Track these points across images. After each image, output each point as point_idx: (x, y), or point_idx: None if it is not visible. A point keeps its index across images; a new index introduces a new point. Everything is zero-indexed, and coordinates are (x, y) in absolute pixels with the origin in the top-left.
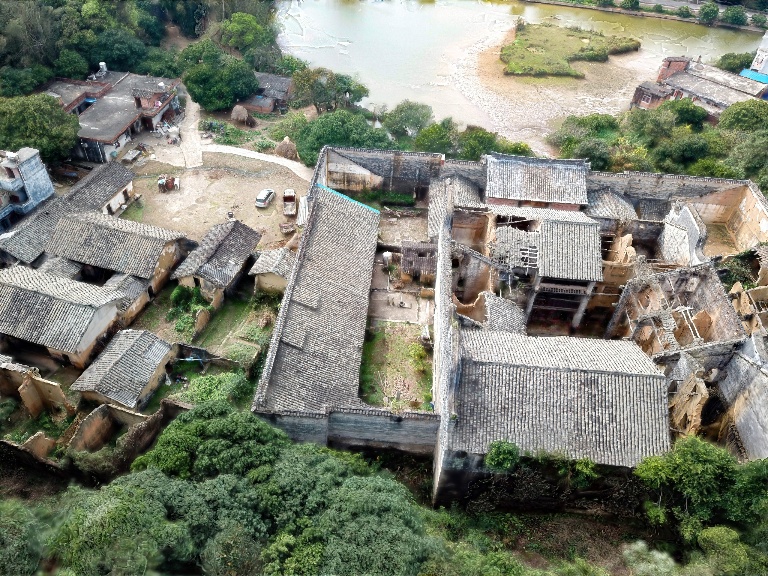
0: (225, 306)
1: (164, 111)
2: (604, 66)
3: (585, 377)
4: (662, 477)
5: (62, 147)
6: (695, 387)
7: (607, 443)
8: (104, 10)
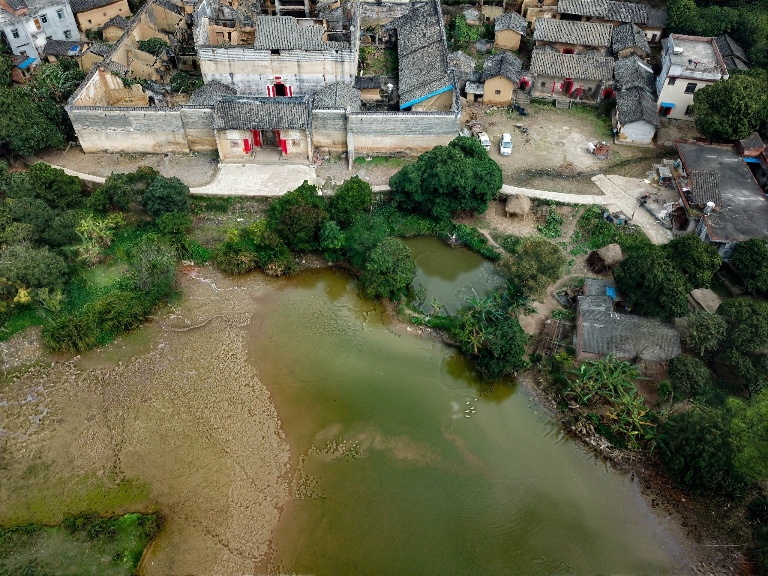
0: None
1: None
2: None
3: None
4: None
5: None
6: None
7: None
8: None
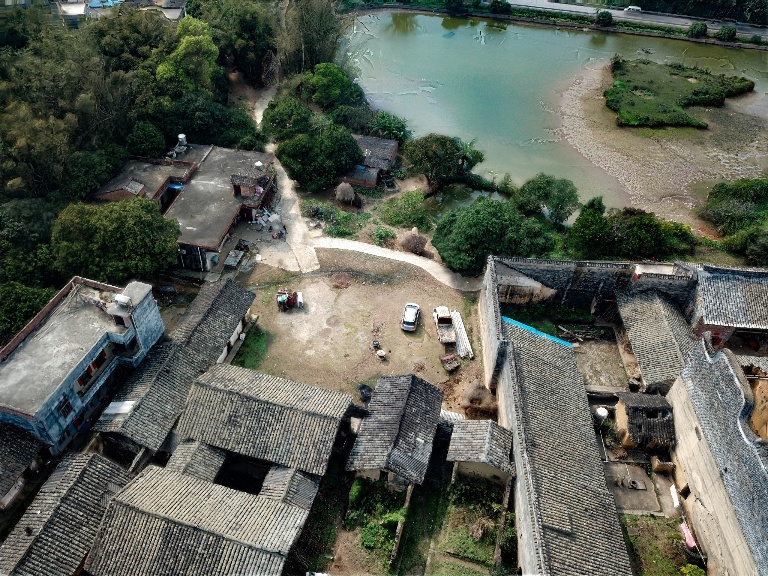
0: (413, 498)
1: None
2: (723, 112)
3: None
4: None
5: (165, 265)
6: None
7: None
8: (181, 71)
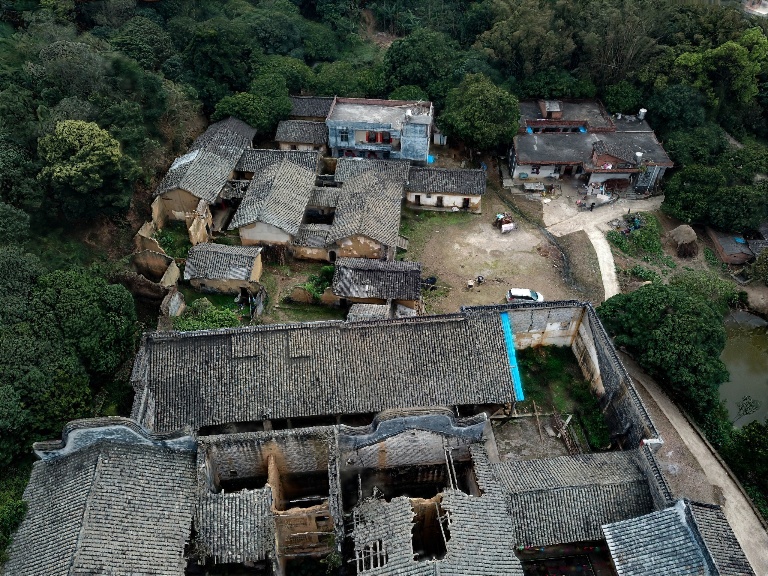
0: (337, 310)
1: (615, 177)
2: None
3: None
4: None
5: (475, 138)
6: None
7: None
8: (700, 66)
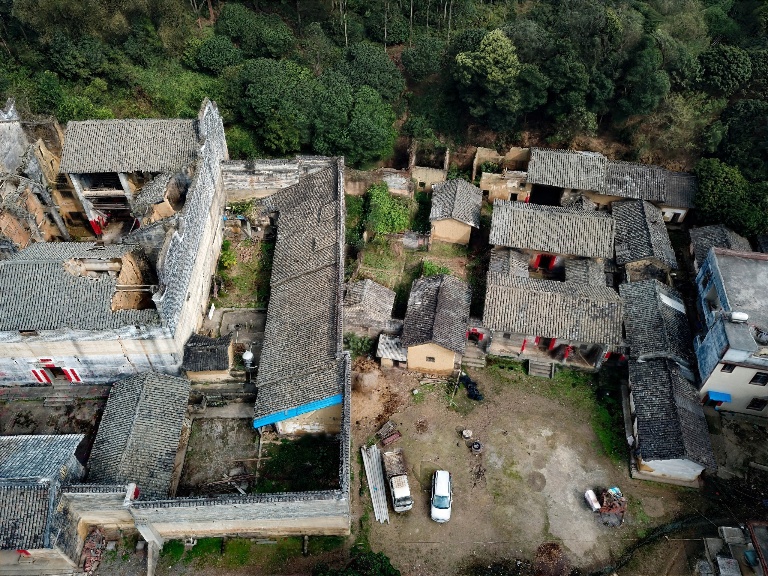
0: None
1: None
2: None
3: None
4: None
5: None
6: None
7: None
8: None
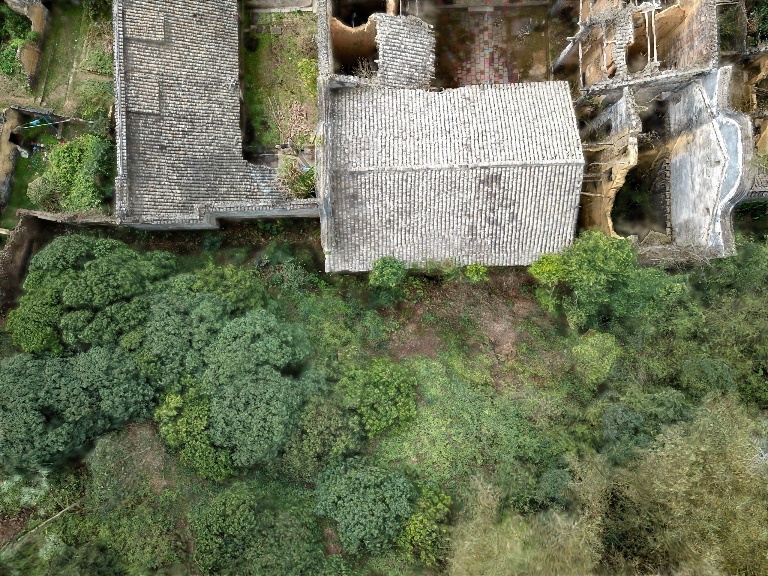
0: (54, 19)
1: None
2: None
3: (485, 174)
4: (554, 282)
5: None
6: (626, 148)
7: (504, 244)
8: None
